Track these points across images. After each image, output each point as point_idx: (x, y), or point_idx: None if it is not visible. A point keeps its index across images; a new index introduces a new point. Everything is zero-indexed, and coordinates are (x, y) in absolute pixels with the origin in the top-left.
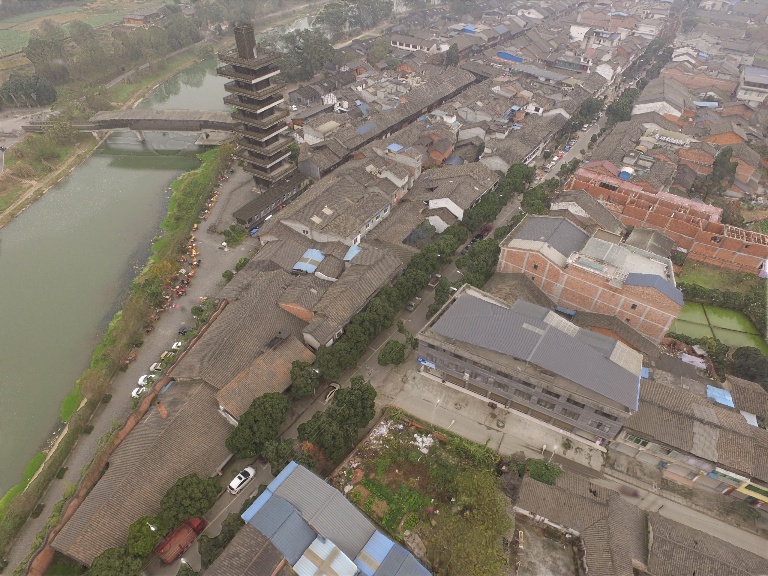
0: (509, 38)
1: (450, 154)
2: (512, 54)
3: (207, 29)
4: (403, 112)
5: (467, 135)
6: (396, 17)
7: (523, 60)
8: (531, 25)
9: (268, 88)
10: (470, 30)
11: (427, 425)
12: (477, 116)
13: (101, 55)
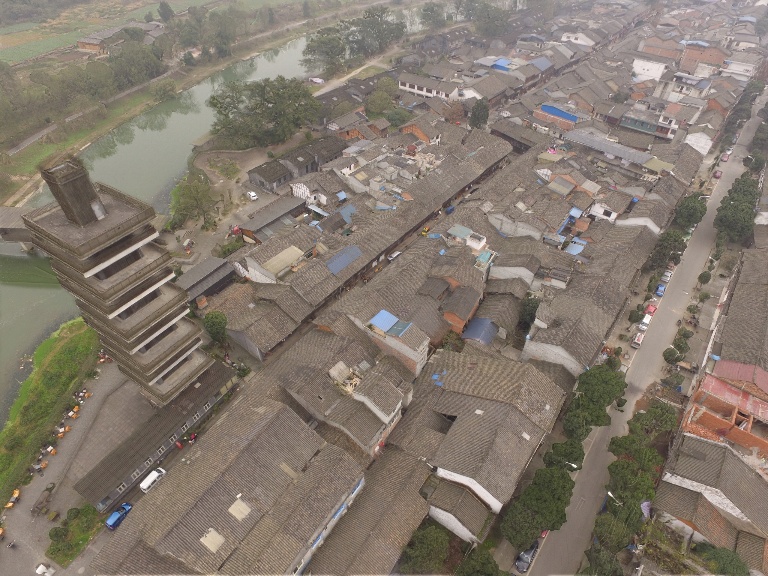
0: (552, 73)
1: (476, 308)
2: (562, 109)
3: (170, 60)
4: (405, 221)
5: (503, 274)
6: (409, 39)
7: (578, 119)
8: (579, 55)
9: (135, 265)
10: (503, 66)
11: None
12: (517, 228)
13: (7, 109)
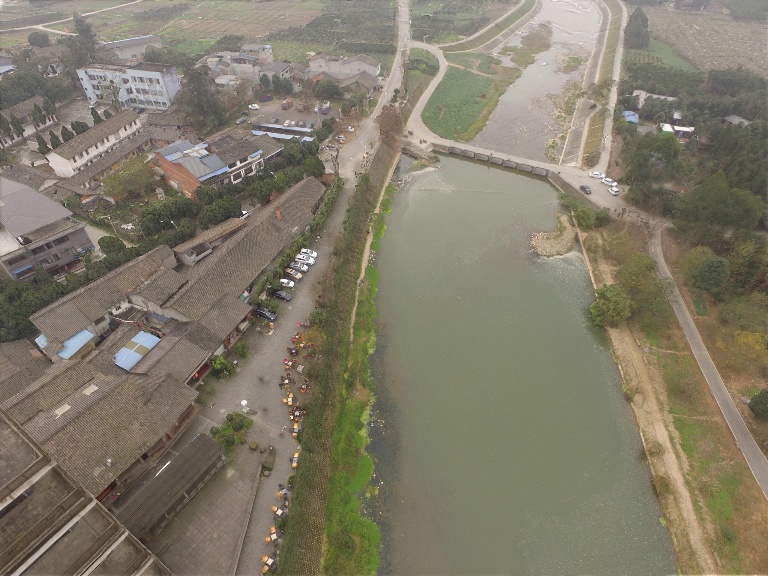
0: None
1: None
2: None
3: None
4: None
5: None
6: None
7: None
8: None
9: None
10: None
11: (119, 236)
12: None
13: None
